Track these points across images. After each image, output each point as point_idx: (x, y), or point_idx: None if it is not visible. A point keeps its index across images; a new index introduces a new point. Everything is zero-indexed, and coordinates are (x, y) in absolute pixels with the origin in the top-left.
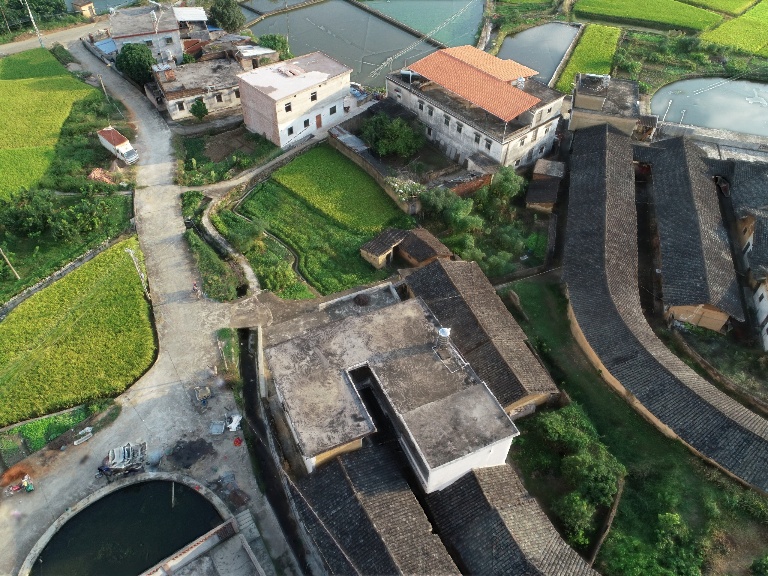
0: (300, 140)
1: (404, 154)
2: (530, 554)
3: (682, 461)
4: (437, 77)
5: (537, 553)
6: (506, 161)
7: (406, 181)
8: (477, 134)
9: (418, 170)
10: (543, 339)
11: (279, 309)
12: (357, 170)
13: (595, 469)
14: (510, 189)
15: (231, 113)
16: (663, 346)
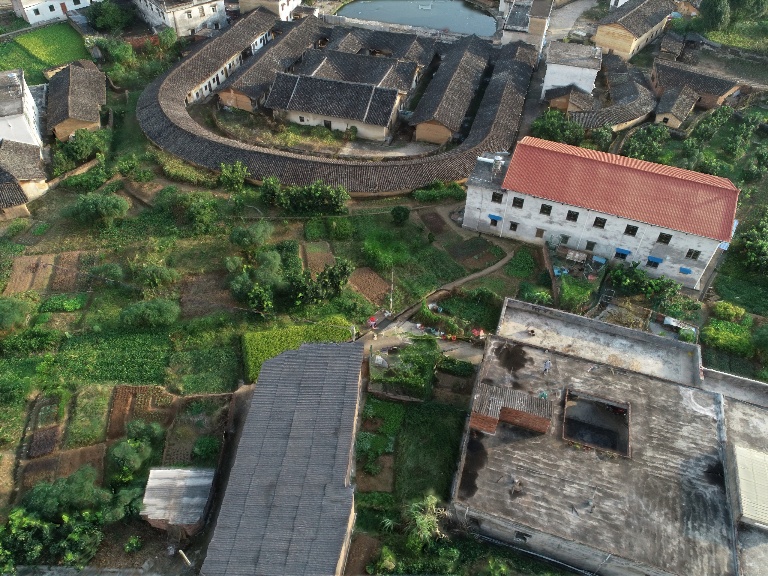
0: (49, 21)
1: (114, 27)
2: None
3: (143, 147)
4: None
5: (9, 164)
6: (178, 28)
7: (97, 37)
8: (157, 9)
9: (116, 35)
10: (126, 110)
11: None
12: (76, 36)
13: (74, 140)
14: (163, 40)
15: (12, 8)
16: (181, 104)
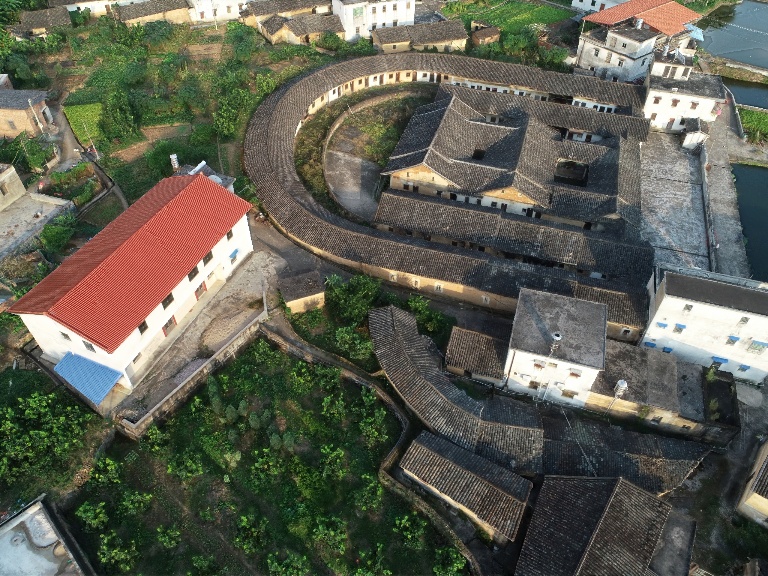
0: (585, 11)
1: None
2: (305, 18)
3: None
4: (632, 2)
5: (305, 21)
6: (582, 58)
7: (542, 27)
8: None
9: None
10: None
11: (434, 6)
12: None
13: None
14: (543, 52)
15: None
16: (407, 68)
